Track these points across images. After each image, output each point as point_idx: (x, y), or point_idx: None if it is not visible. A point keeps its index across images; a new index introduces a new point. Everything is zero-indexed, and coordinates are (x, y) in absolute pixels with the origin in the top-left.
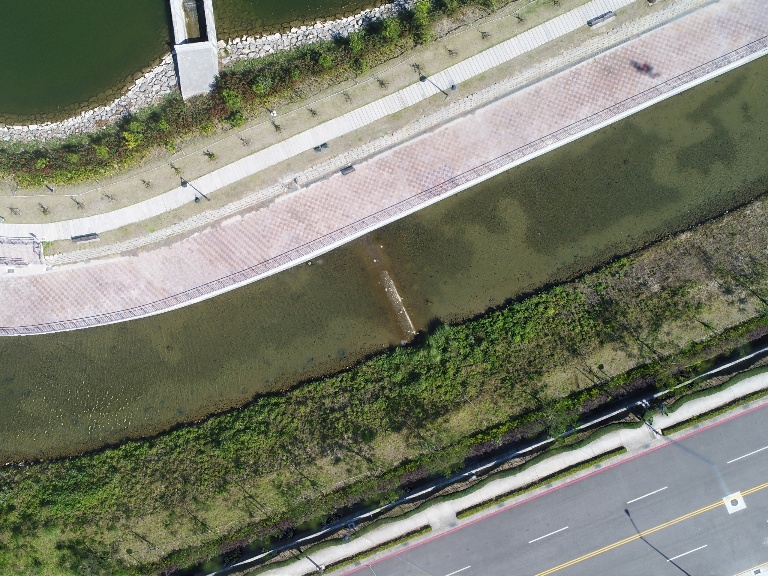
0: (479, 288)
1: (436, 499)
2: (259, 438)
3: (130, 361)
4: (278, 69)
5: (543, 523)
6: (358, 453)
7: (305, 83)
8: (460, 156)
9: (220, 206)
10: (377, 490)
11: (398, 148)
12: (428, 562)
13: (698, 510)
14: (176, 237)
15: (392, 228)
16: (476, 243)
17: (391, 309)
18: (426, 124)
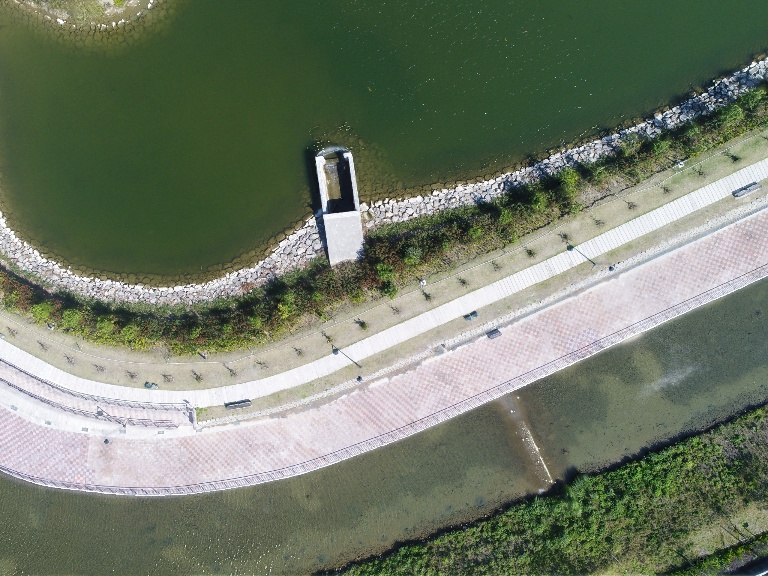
0: (615, 437)
1: None
2: None
3: (270, 510)
4: (425, 236)
5: None
6: None
7: (452, 251)
8: (604, 319)
9: (371, 373)
10: None
11: (543, 312)
12: None
13: None
14: (324, 399)
15: None
16: (611, 393)
17: (528, 458)
18: (571, 289)
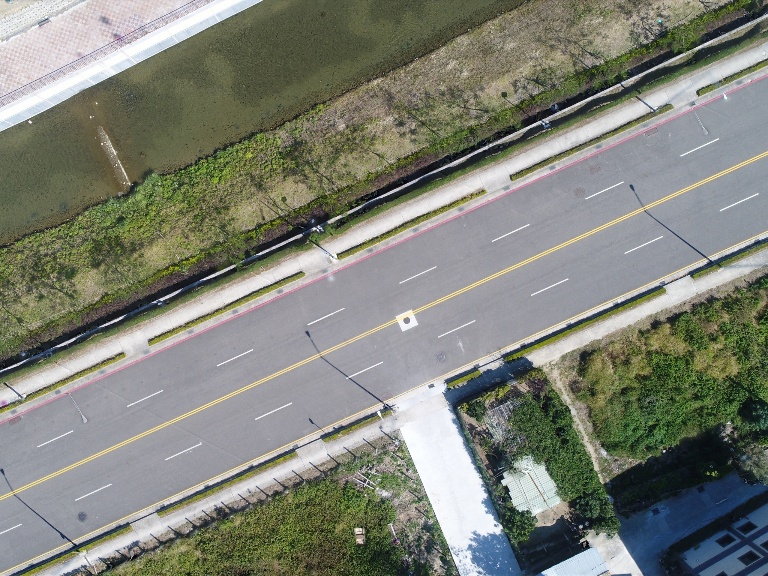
0: (189, 140)
1: (123, 324)
2: None
3: None
4: None
5: (230, 347)
6: (60, 290)
7: None
8: (148, 5)
9: None
10: (76, 323)
11: None
12: (124, 388)
13: (373, 329)
14: None
15: (106, 85)
16: (186, 97)
17: (107, 163)
18: None
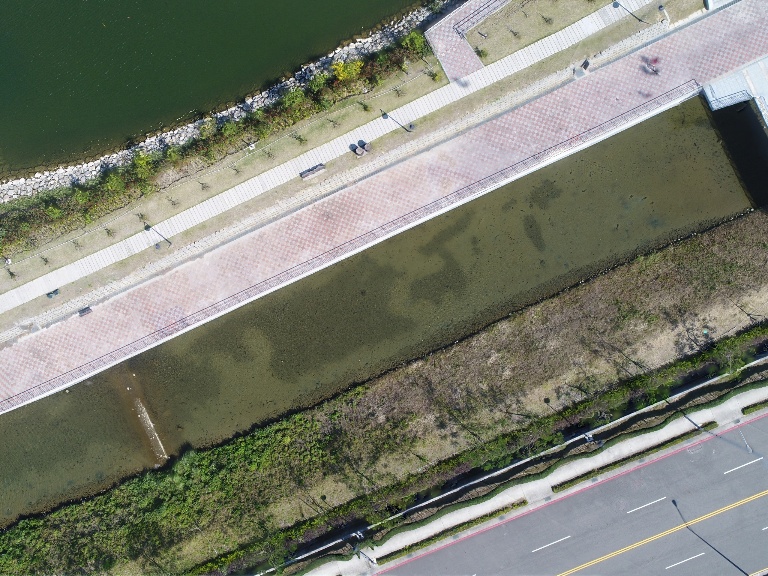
0: (227, 414)
1: None
2: (12, 562)
3: None
4: (16, 217)
5: None
6: None
7: (40, 231)
8: (190, 298)
9: None
10: None
11: (132, 290)
12: None
13: None
14: None
15: (144, 357)
16: (224, 371)
17: (144, 434)
18: (156, 268)
